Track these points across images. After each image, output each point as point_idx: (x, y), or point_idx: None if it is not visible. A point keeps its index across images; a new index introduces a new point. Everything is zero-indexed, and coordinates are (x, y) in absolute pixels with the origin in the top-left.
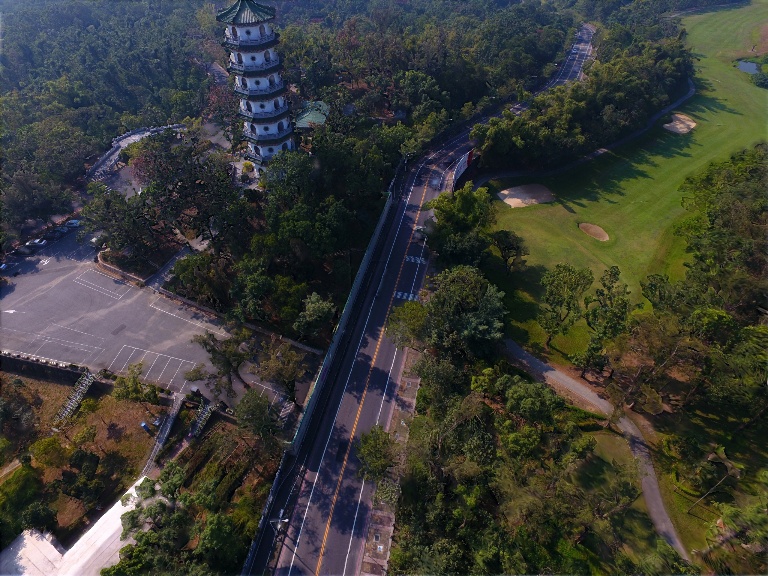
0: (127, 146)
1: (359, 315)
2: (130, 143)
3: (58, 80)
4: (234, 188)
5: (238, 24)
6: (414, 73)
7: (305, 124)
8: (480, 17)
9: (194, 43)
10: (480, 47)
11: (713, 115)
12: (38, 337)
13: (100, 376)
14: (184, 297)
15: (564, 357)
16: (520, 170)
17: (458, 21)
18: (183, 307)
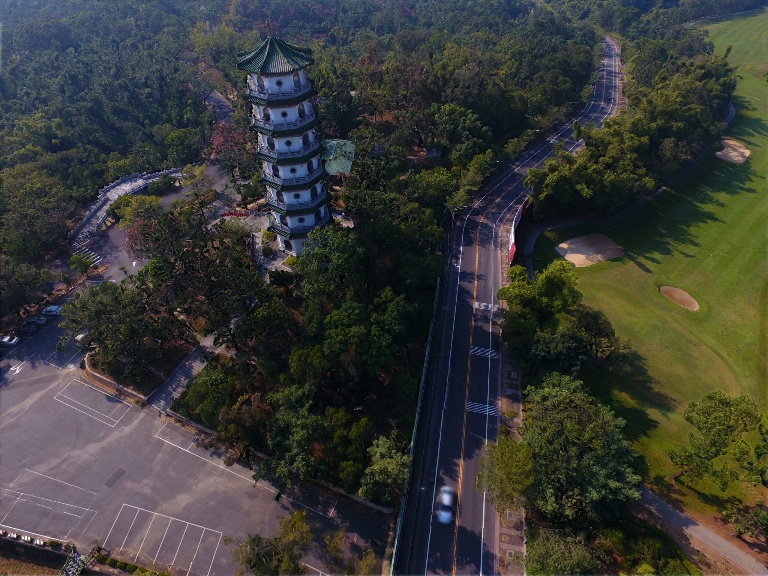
0: (117, 200)
1: (427, 440)
2: (120, 196)
3: (33, 118)
4: (255, 266)
5: (267, 74)
6: (452, 107)
7: (329, 171)
8: (493, 30)
9: (190, 70)
10: (510, 69)
11: (764, 139)
12: (6, 493)
13: (92, 559)
14: (200, 424)
15: (701, 499)
16: (577, 217)
17: (476, 37)
18: (199, 437)
